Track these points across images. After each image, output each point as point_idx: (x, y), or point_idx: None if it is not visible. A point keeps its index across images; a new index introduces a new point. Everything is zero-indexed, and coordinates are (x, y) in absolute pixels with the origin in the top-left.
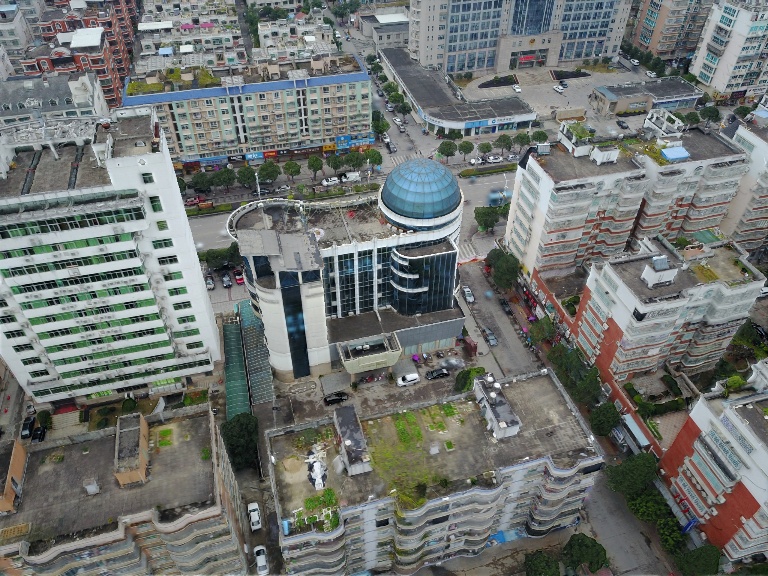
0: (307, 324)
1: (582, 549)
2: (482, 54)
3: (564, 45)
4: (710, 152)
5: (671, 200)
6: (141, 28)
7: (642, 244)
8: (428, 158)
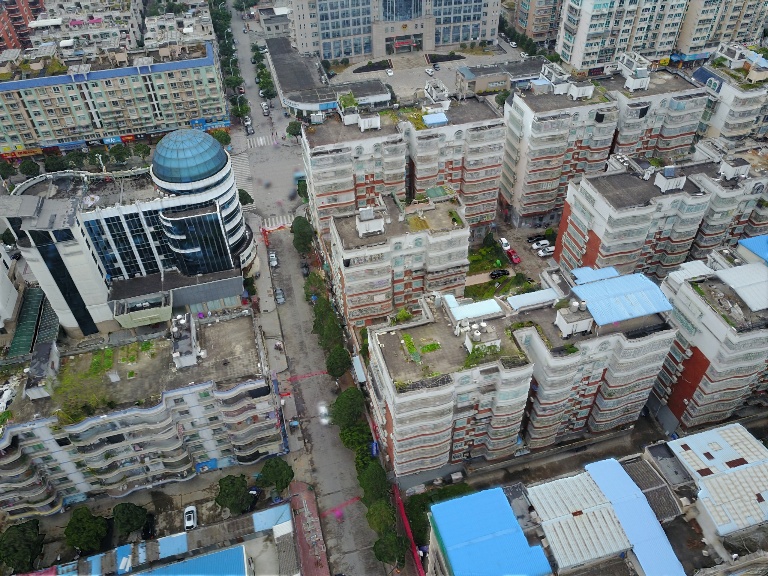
0: (77, 282)
1: (267, 469)
2: (358, 40)
3: (440, 30)
4: (474, 118)
5: (437, 163)
6: (31, 25)
7: None
8: (281, 139)
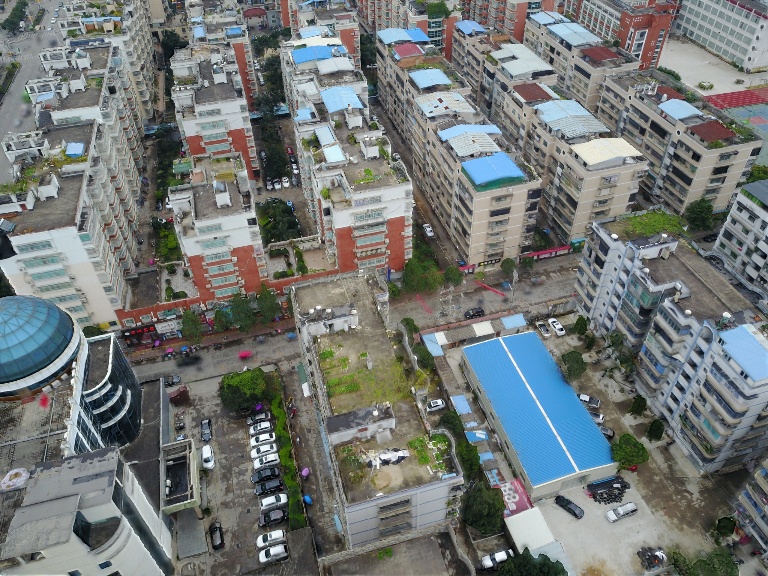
0: (146, 521)
1: (408, 328)
2: None
3: None
4: (78, 136)
5: None
6: None
7: (174, 202)
8: None
